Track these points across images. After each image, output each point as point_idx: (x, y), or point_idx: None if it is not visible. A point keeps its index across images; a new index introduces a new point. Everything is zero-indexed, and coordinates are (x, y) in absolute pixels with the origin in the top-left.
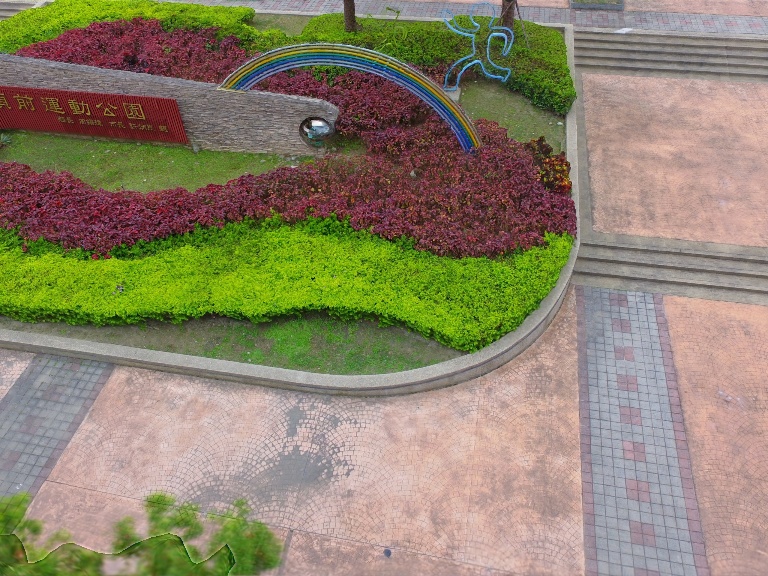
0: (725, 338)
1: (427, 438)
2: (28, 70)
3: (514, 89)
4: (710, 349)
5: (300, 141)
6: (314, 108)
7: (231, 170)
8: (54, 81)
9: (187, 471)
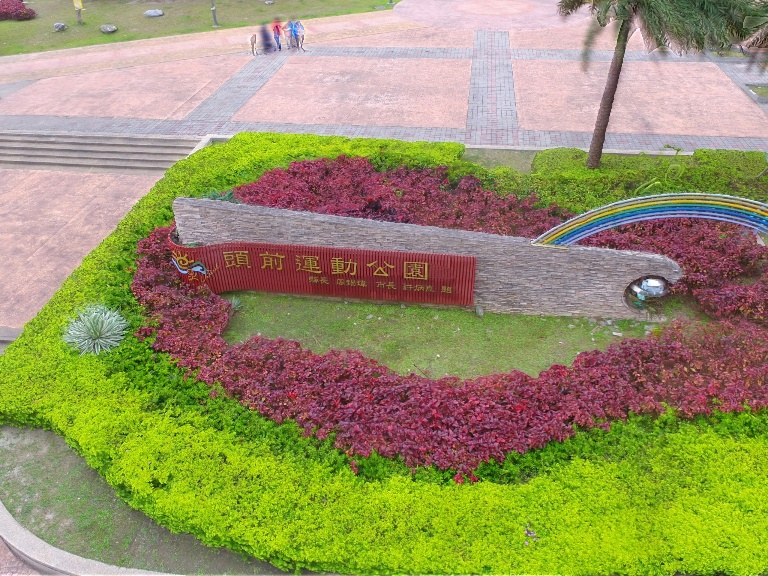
0: None
1: None
2: (288, 224)
3: None
4: None
5: (621, 302)
6: (656, 266)
7: (538, 339)
8: (317, 236)
9: None
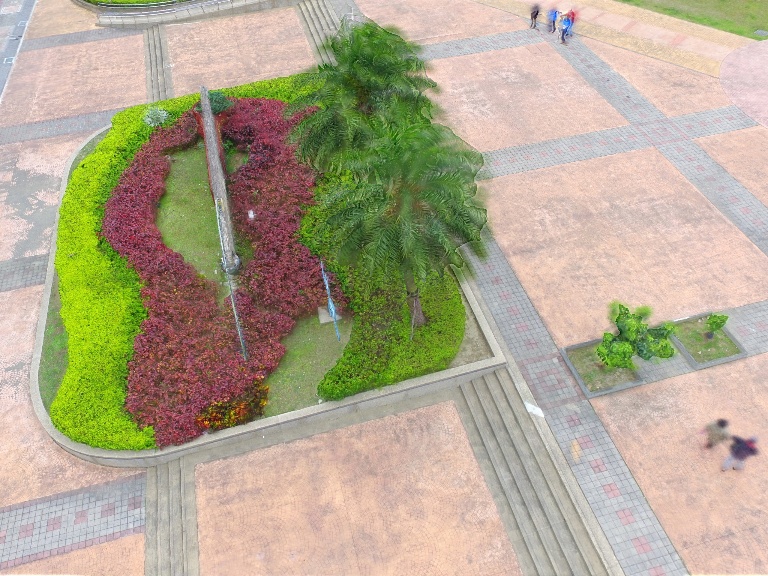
0: None
1: (6, 429)
2: None
3: None
4: (91, 573)
5: None
6: None
7: (205, 245)
8: None
9: None
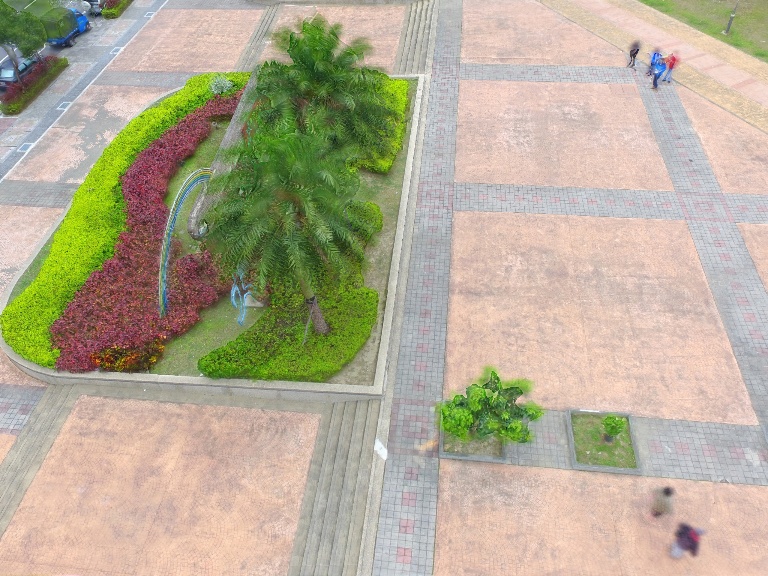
0: None
1: None
2: None
3: None
4: None
5: None
6: None
7: None
8: None
9: (1, 242)
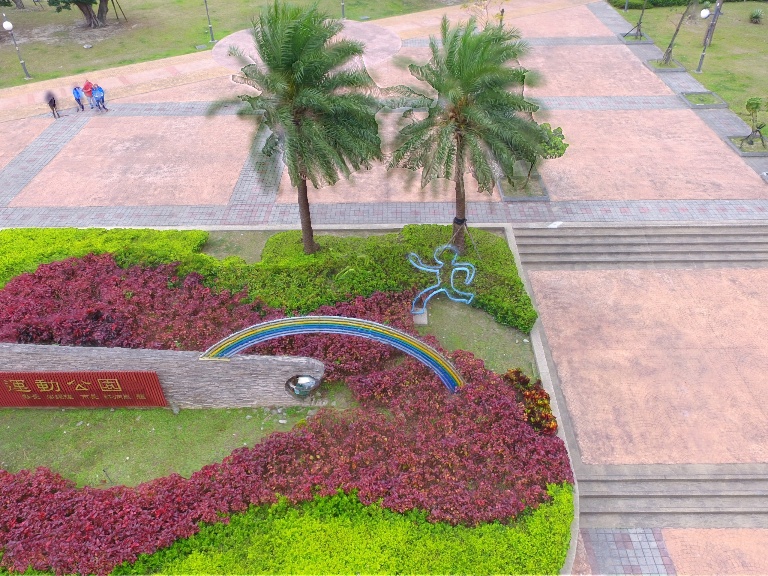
0: (727, 574)
1: None
2: None
3: (477, 307)
4: None
5: (286, 395)
6: (301, 368)
7: (217, 433)
8: (19, 364)
9: None
